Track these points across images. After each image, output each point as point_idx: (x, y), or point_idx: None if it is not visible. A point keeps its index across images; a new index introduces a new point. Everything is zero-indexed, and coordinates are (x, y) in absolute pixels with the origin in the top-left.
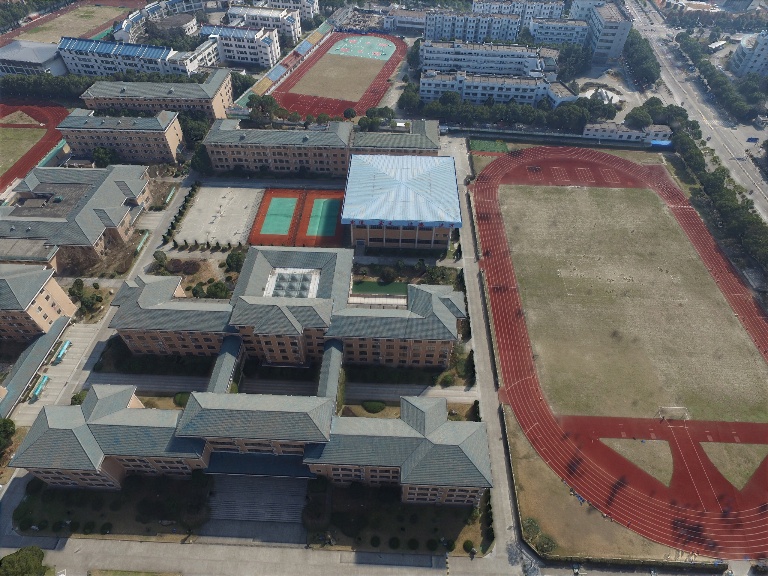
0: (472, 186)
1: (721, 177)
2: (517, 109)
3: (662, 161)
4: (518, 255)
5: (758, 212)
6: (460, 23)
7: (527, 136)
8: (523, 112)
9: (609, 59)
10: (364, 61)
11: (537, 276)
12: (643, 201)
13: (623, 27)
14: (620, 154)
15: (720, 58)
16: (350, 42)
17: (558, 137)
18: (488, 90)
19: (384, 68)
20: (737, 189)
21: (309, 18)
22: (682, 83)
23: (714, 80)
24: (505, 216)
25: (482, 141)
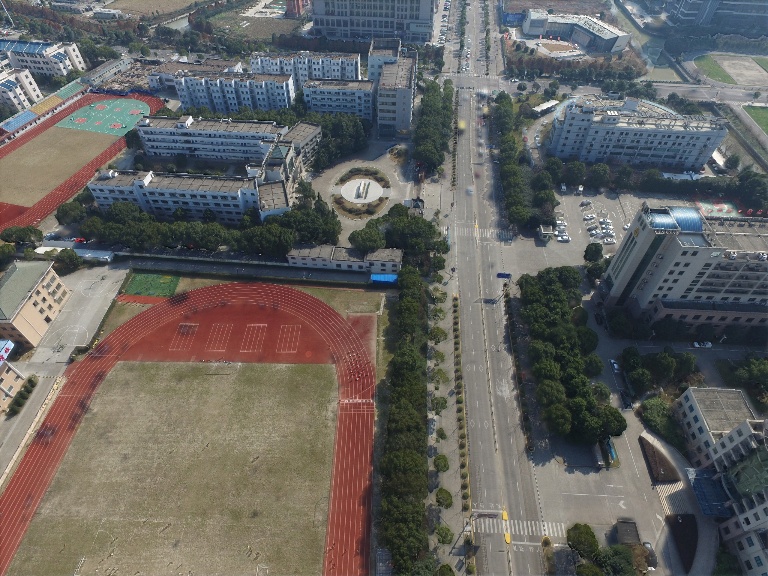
0: (74, 366)
1: (408, 361)
2: (192, 232)
3: (378, 308)
4: (42, 522)
5: (464, 411)
6: (215, 87)
7: (218, 264)
8: (202, 235)
9: (398, 131)
10: (91, 138)
11: (39, 575)
12: (307, 391)
13: (402, 95)
14: (327, 295)
15: (545, 125)
16: (96, 108)
17: (258, 266)
18: (178, 197)
19: (108, 149)
20: (437, 375)
21: (60, 76)
22: (478, 166)
23: (502, 169)
24: (81, 430)
25: (148, 276)
